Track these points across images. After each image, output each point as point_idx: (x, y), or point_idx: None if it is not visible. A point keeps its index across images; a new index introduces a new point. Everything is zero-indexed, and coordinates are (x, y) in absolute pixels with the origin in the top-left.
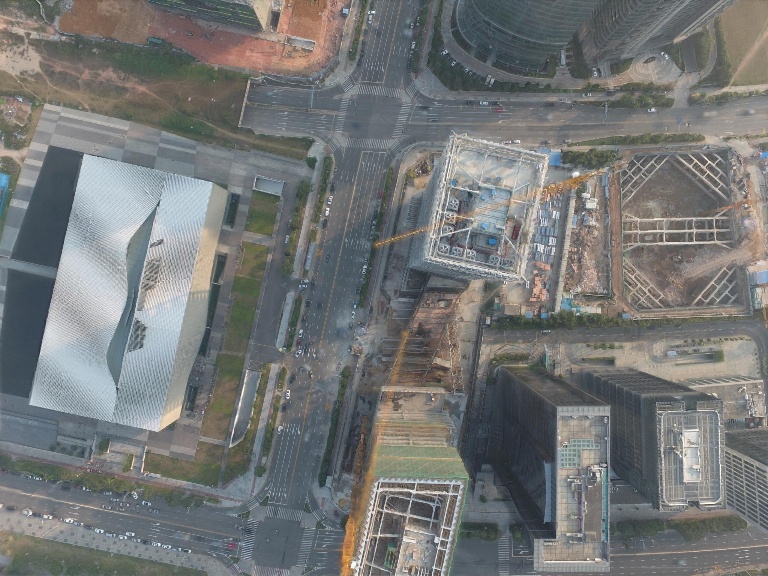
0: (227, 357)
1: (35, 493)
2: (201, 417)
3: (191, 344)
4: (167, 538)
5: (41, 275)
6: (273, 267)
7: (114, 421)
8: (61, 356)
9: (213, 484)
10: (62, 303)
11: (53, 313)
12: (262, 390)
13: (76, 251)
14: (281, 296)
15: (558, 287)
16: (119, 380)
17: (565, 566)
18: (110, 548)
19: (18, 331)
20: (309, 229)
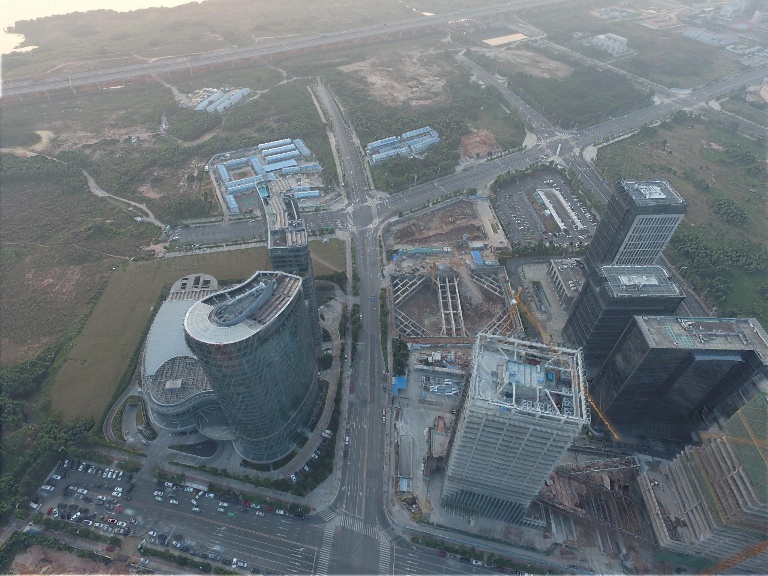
0: None
1: None
2: None
3: None
4: None
5: None
6: None
7: None
8: None
9: None
10: None
11: None
12: None
13: None
14: None
15: None
16: None
17: None
18: None
19: None
20: None
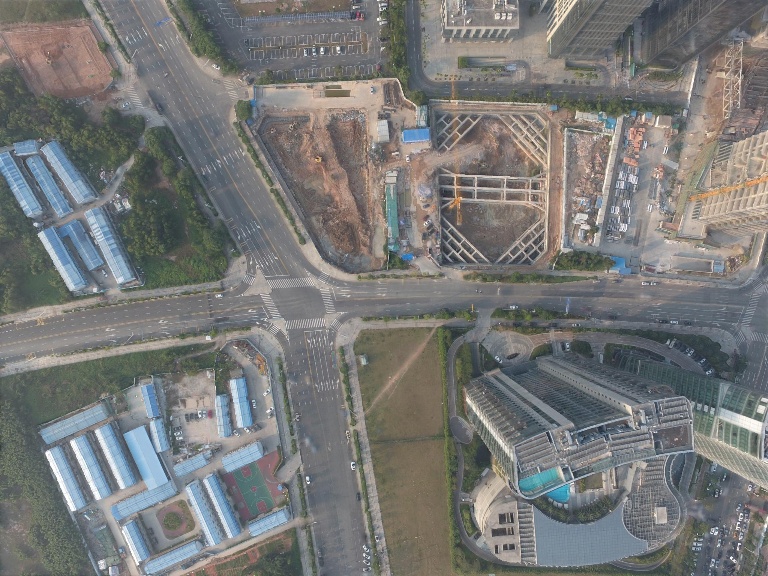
0: None
1: None
2: None
3: None
4: None
5: None
6: None
7: None
8: None
9: None
10: None
11: None
12: None
13: None
14: None
15: None
16: None
17: None
18: None
19: None
20: None
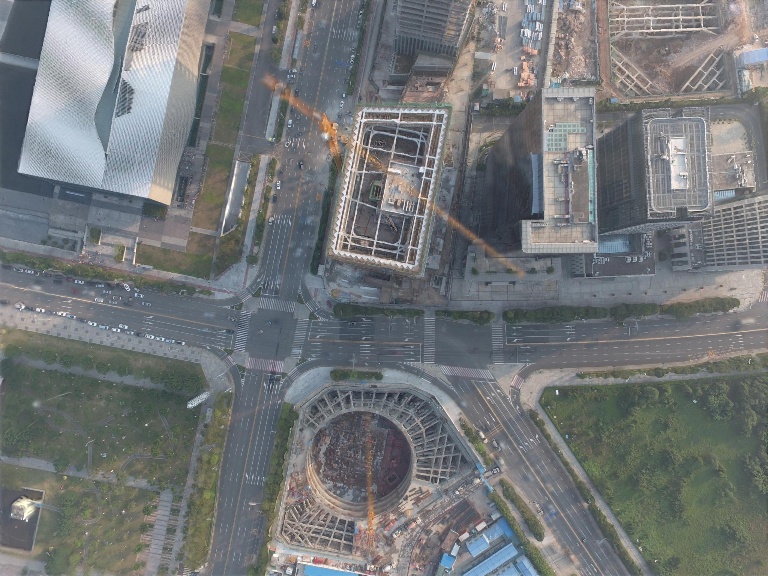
0: (217, 148)
1: (27, 287)
2: (192, 207)
3: (180, 122)
4: (160, 331)
5: (29, 67)
6: (261, 58)
7: (103, 187)
8: (49, 121)
9: (205, 276)
10: (49, 69)
11: (40, 80)
12: (252, 181)
13: (62, 16)
14: (269, 87)
15: (546, 71)
16: (108, 146)
17: (553, 247)
18: (103, 341)
19: (7, 125)
20: (296, 20)
